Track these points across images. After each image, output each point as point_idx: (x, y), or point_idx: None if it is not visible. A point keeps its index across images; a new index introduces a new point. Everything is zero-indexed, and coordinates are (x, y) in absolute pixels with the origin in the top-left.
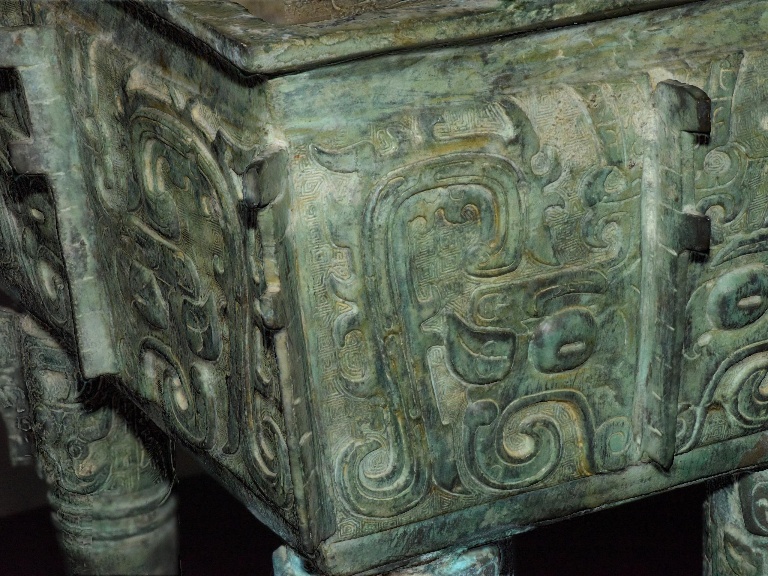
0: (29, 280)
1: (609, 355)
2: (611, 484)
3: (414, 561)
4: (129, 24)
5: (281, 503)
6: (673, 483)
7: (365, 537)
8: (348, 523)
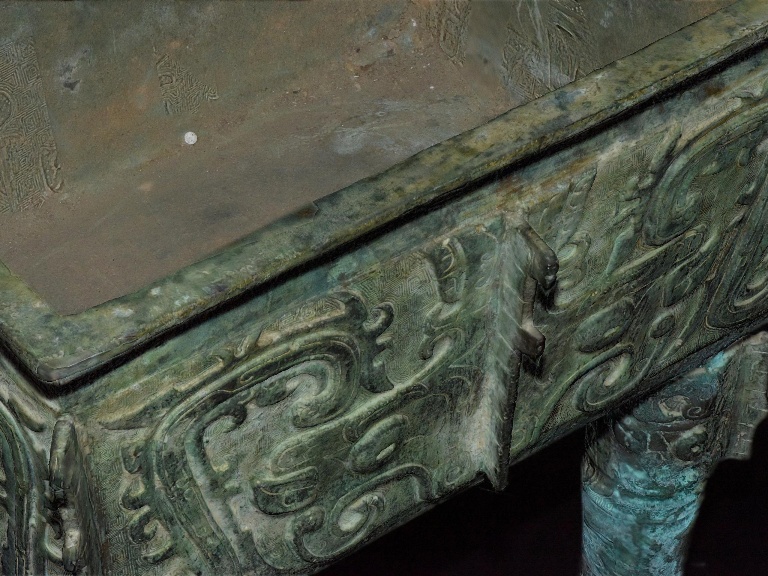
0: (278, 570)
1: None
2: None
3: None
4: (642, 112)
5: None
6: None
7: None
8: None
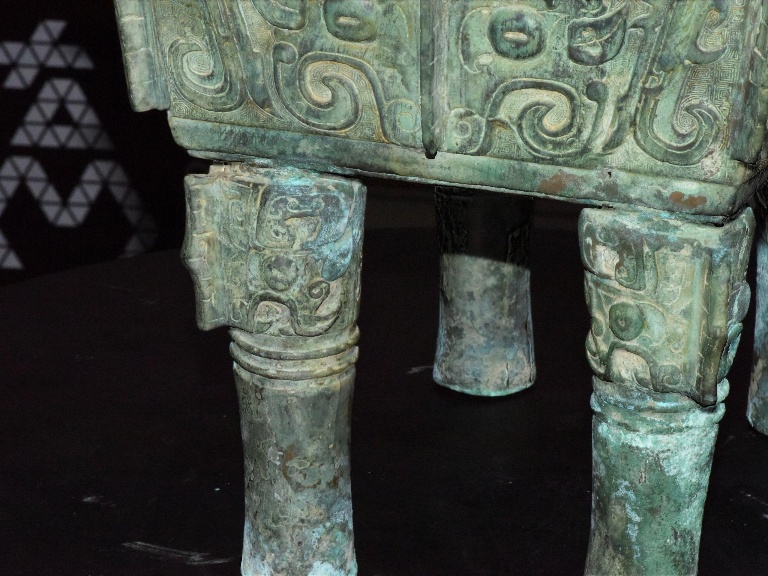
0: None
1: (394, 42)
2: (413, 159)
3: (250, 161)
4: None
5: None
6: (474, 181)
7: (200, 122)
8: (181, 104)
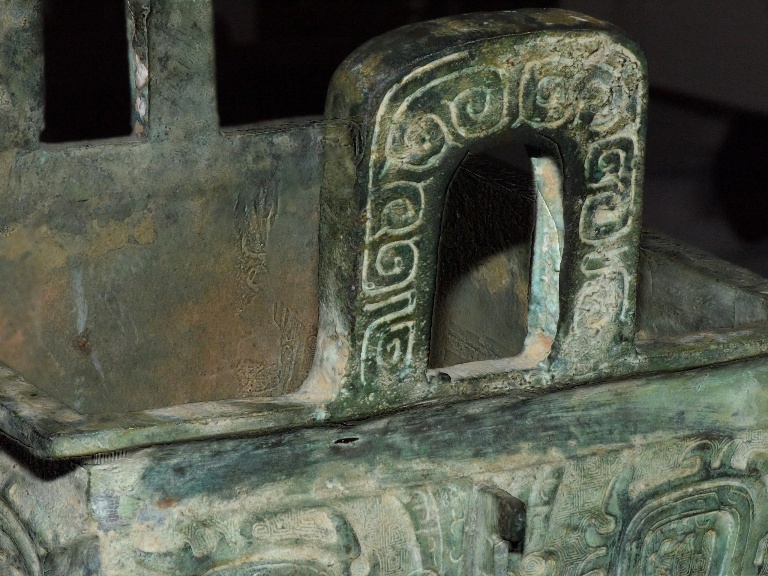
0: None
1: None
2: None
3: None
4: None
5: None
6: None
7: None
8: None
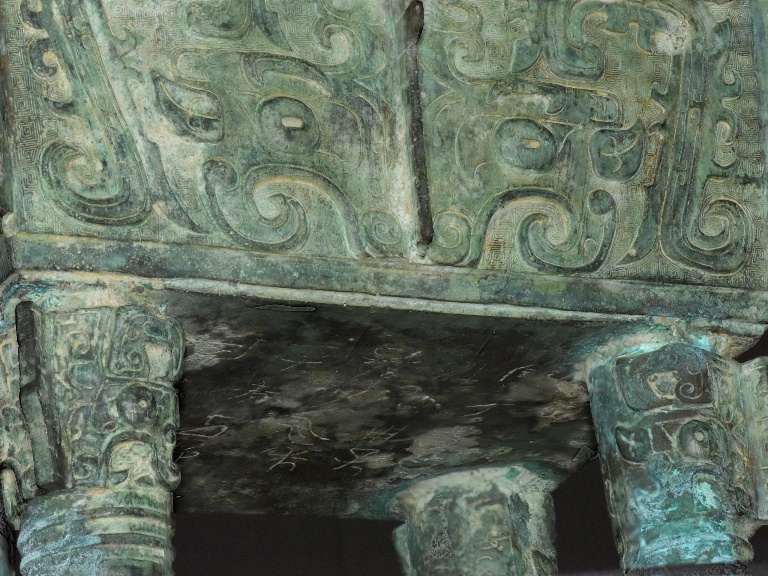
0: None
1: None
2: None
3: None
4: None
5: (739, 263)
6: None
7: None
8: None
